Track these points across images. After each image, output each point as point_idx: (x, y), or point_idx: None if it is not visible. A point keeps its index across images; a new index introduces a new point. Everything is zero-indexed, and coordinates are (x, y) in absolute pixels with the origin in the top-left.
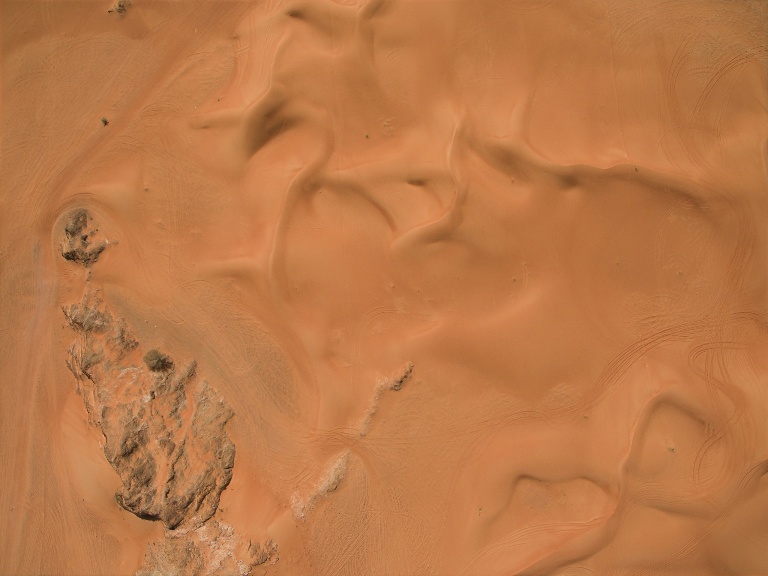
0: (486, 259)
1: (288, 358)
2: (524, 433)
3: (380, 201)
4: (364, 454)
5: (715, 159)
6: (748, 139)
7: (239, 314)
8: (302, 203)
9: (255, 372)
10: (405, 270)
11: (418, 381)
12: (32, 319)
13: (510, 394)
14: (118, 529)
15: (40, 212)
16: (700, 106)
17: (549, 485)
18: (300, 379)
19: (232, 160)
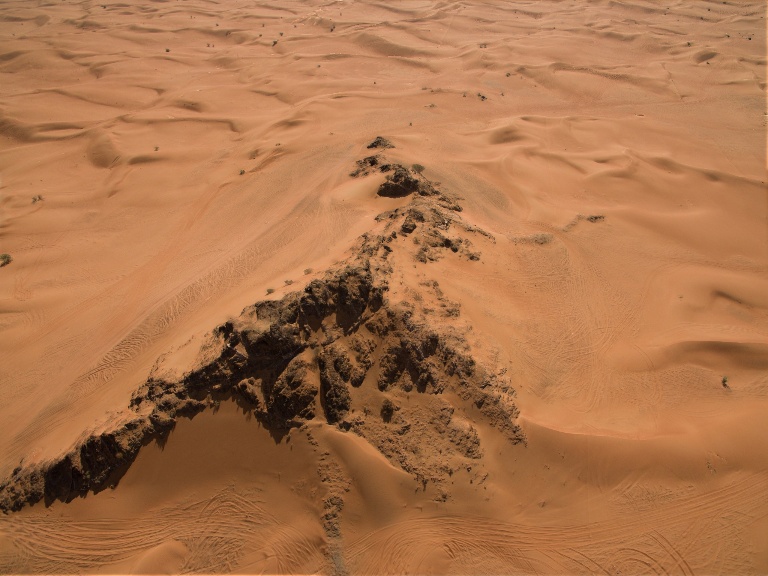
0: (656, 192)
1: (507, 195)
2: (713, 271)
3: (575, 164)
4: (565, 240)
5: None
6: None
7: (475, 176)
8: (524, 155)
9: (482, 193)
10: (594, 186)
11: (609, 224)
12: (333, 164)
13: (692, 250)
14: (368, 207)
15: (361, 137)
16: None
17: (751, 308)
18: (514, 204)
19: (480, 142)
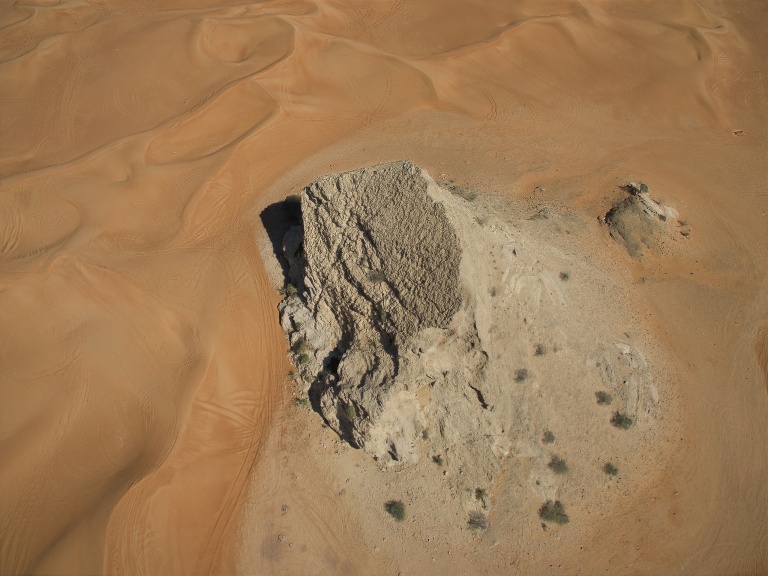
0: None
1: None
2: None
3: None
4: None
5: (448, 73)
6: (442, 81)
7: None
8: None
9: None
10: None
11: None
12: None
13: None
14: None
15: None
16: (486, 92)
17: None
18: None
19: None
